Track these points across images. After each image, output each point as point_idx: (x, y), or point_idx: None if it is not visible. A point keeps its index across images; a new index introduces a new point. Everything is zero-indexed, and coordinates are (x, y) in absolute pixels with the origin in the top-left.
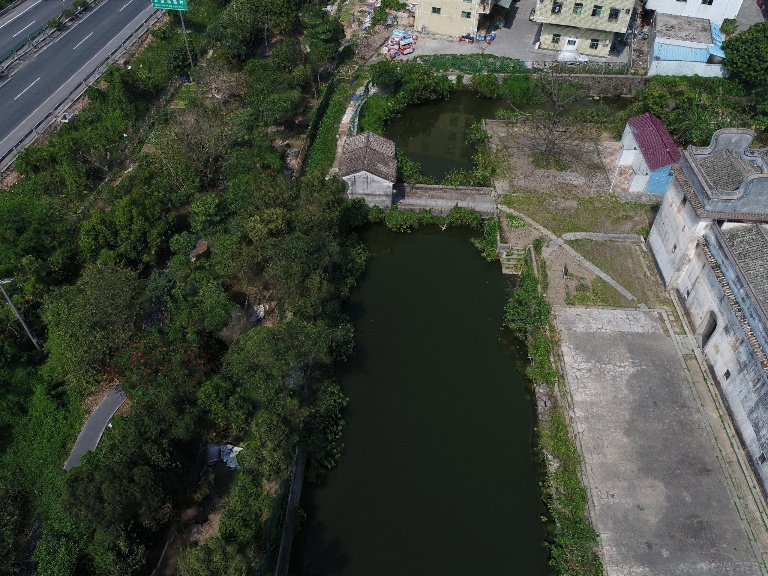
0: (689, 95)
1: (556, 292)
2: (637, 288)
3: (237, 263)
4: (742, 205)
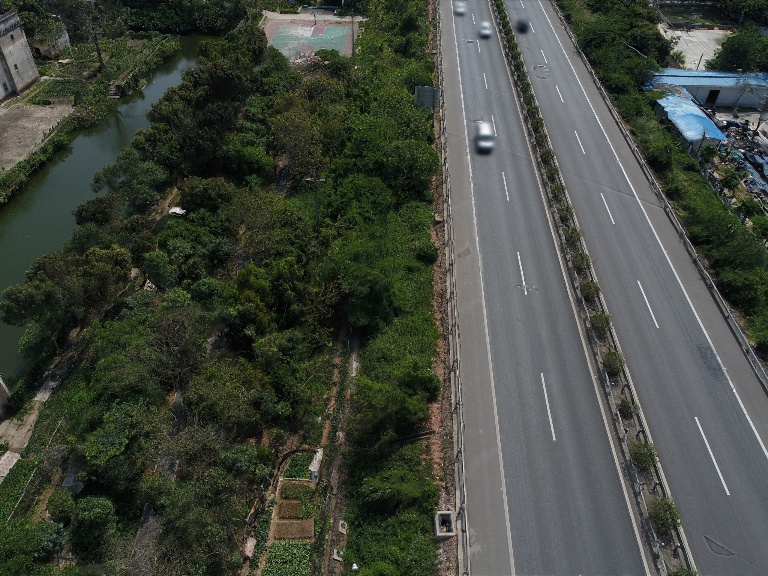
0: None
1: None
2: None
3: (144, 216)
4: None
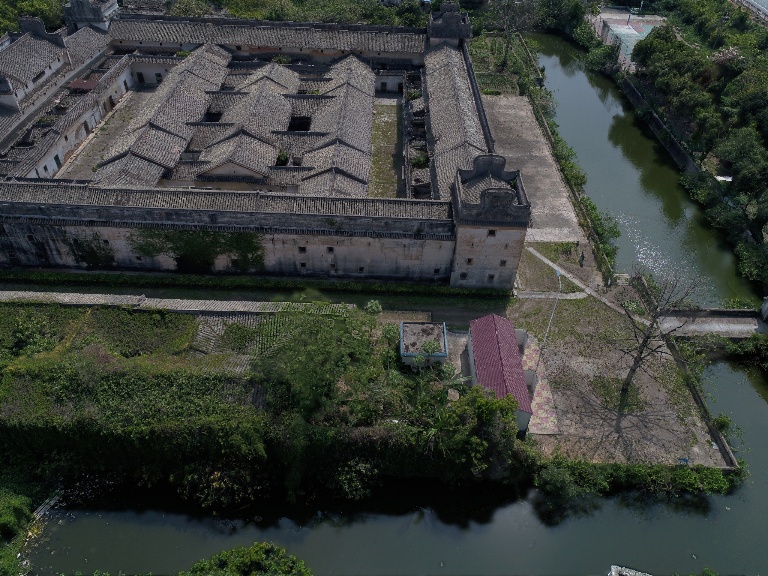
0: (459, 399)
1: (586, 250)
2: (525, 255)
3: None
4: None
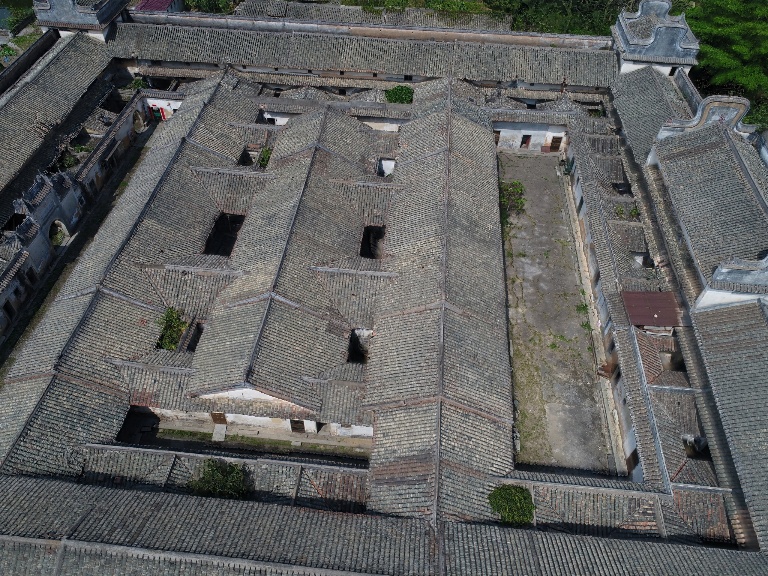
0: None
1: None
2: None
3: None
4: (58, 15)
